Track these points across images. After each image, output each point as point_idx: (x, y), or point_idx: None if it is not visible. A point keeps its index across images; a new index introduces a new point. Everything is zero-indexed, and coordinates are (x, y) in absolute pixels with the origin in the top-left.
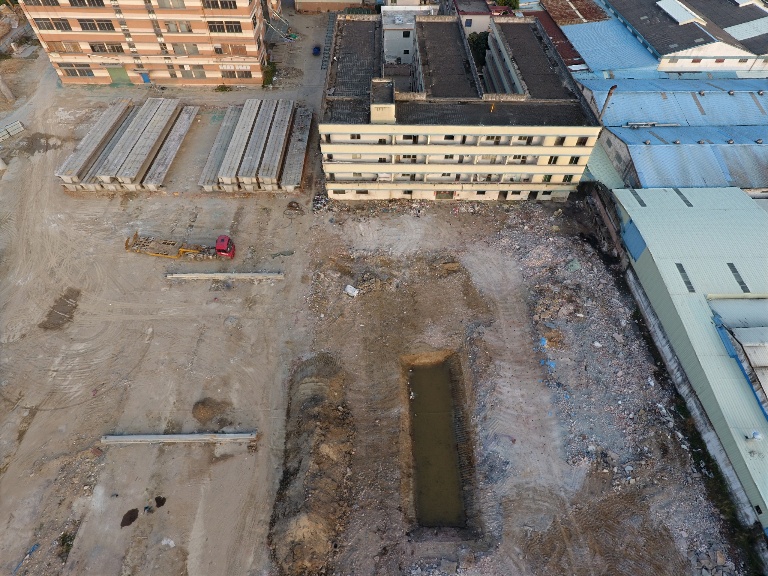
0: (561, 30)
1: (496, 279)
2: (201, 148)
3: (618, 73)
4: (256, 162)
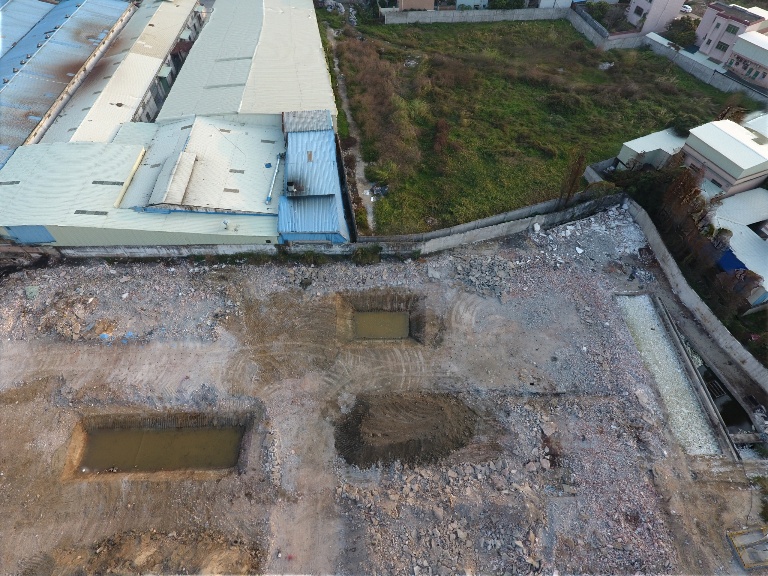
0: None
1: (8, 367)
2: None
3: None
4: None
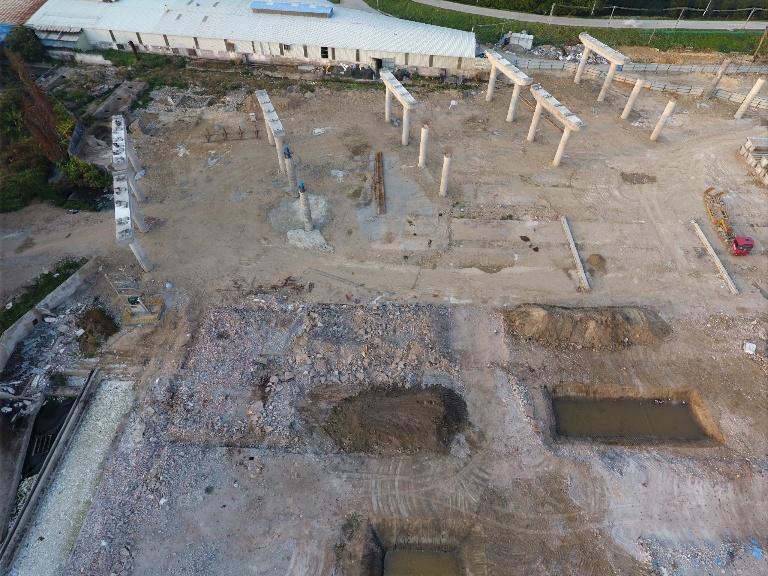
0: None
1: None
2: None
3: None
4: None
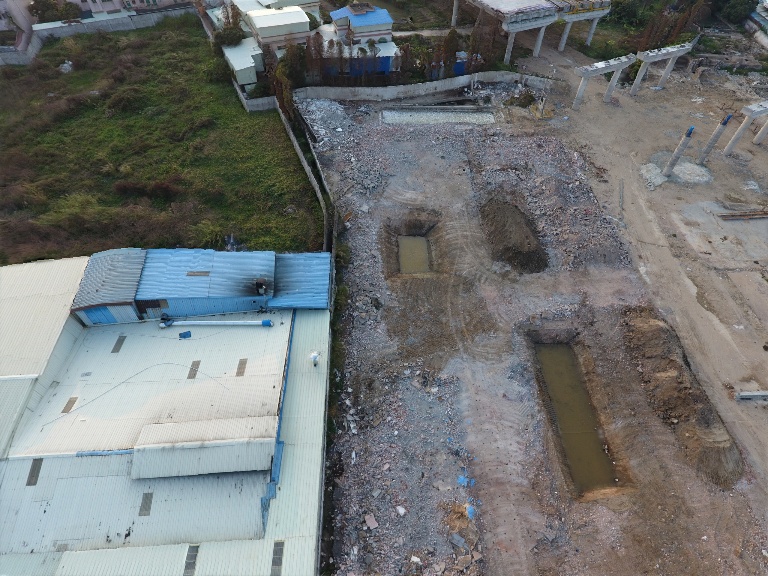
0: None
1: None
2: None
3: None
4: None
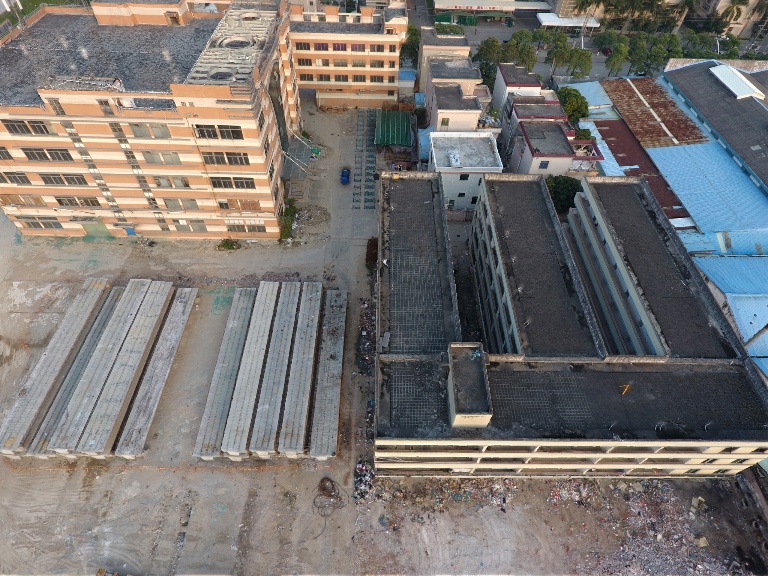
0: (648, 155)
1: None
2: (199, 363)
3: (735, 235)
4: (275, 417)
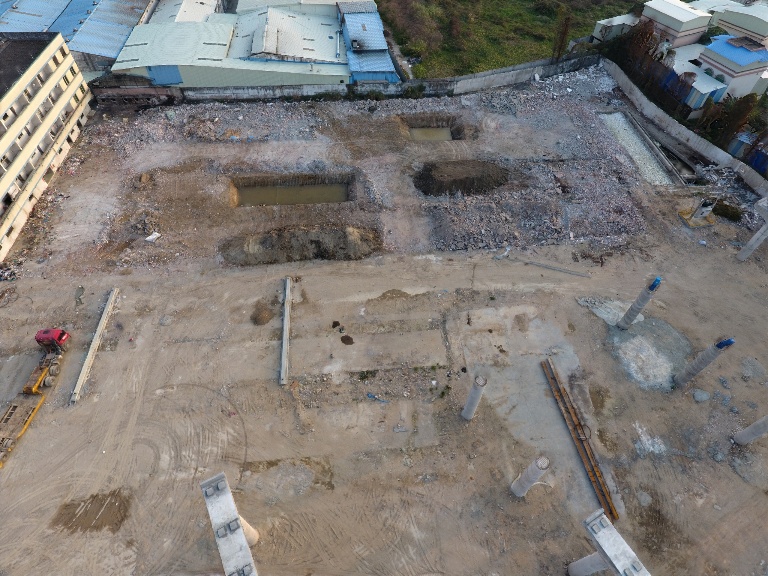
0: None
1: (169, 155)
2: None
3: None
4: None
